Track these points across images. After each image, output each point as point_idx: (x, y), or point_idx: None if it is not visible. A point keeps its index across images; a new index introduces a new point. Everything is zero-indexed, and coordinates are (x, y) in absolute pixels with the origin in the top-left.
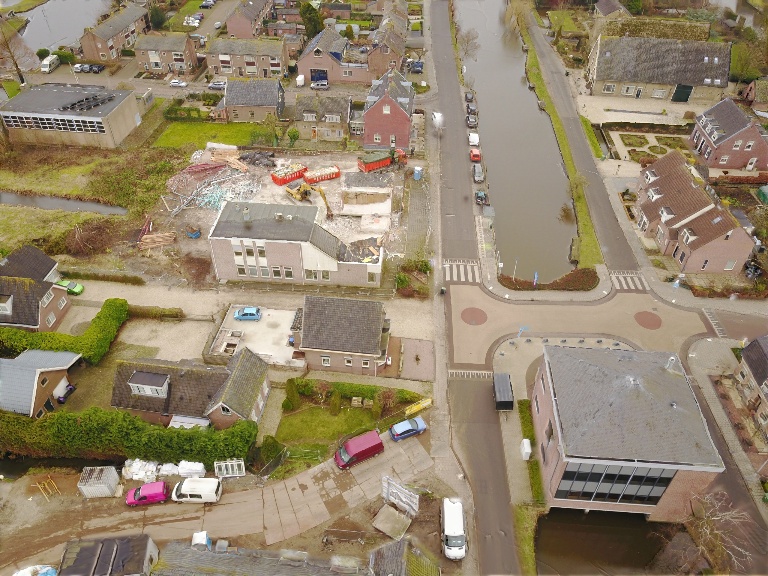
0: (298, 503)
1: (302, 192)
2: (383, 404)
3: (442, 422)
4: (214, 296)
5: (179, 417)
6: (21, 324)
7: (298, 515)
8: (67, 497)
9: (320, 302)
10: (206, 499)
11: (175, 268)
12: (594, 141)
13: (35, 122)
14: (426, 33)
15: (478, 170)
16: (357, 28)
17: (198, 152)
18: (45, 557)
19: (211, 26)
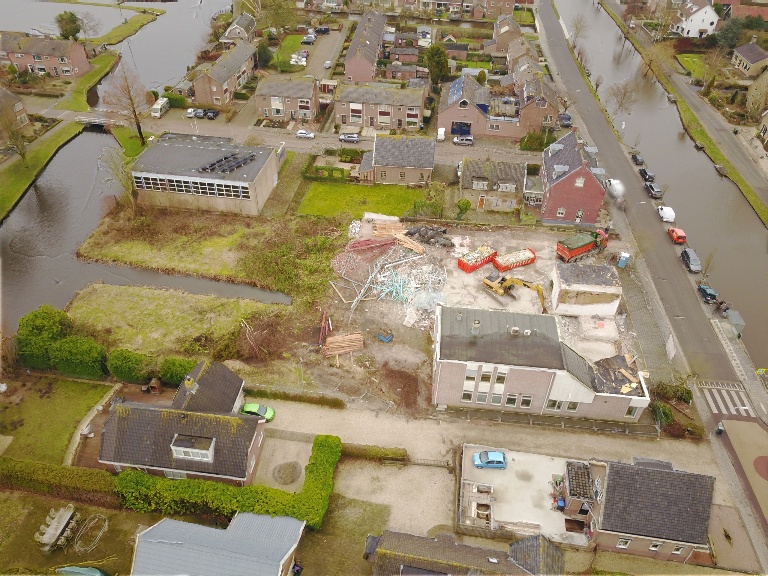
0: None
1: (507, 287)
2: None
3: None
4: (435, 428)
5: None
6: (224, 475)
7: None
8: None
9: (629, 473)
10: None
11: (374, 384)
12: None
13: (170, 184)
14: (556, 78)
15: (693, 257)
16: (486, 73)
17: (355, 223)
18: None
19: (319, 65)
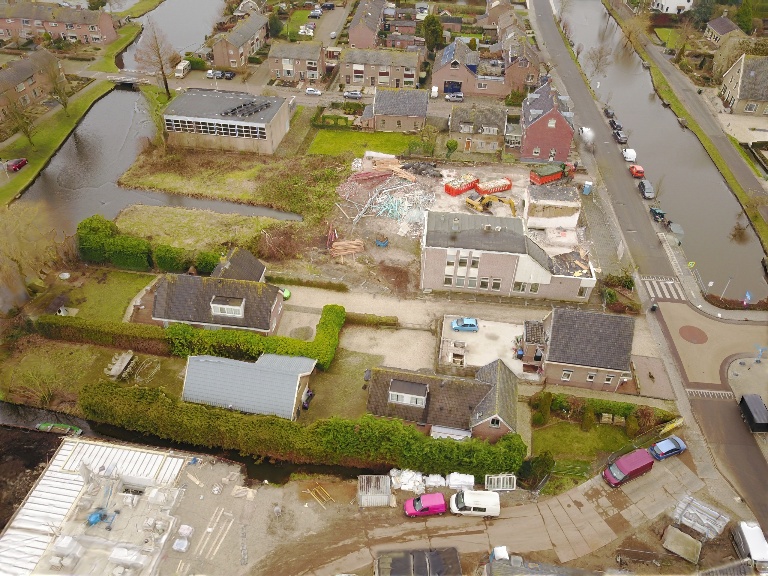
0: (579, 520)
1: (486, 203)
2: (643, 422)
3: (698, 442)
4: (422, 305)
5: (439, 428)
6: (253, 328)
7: (583, 533)
8: (342, 505)
9: (570, 316)
10: (489, 513)
11: (372, 276)
12: (749, 160)
13: (197, 126)
14: (542, 48)
15: (648, 186)
16: (477, 41)
17: (357, 160)
18: (341, 566)
19: (325, 36)
